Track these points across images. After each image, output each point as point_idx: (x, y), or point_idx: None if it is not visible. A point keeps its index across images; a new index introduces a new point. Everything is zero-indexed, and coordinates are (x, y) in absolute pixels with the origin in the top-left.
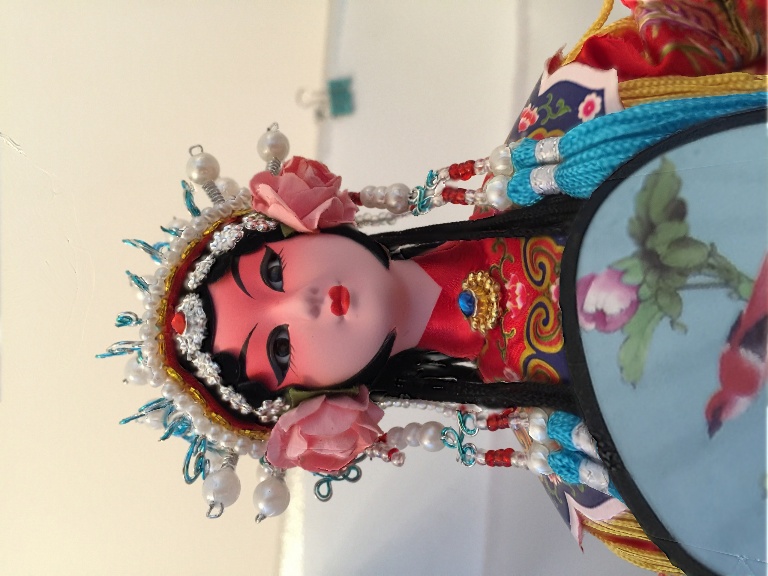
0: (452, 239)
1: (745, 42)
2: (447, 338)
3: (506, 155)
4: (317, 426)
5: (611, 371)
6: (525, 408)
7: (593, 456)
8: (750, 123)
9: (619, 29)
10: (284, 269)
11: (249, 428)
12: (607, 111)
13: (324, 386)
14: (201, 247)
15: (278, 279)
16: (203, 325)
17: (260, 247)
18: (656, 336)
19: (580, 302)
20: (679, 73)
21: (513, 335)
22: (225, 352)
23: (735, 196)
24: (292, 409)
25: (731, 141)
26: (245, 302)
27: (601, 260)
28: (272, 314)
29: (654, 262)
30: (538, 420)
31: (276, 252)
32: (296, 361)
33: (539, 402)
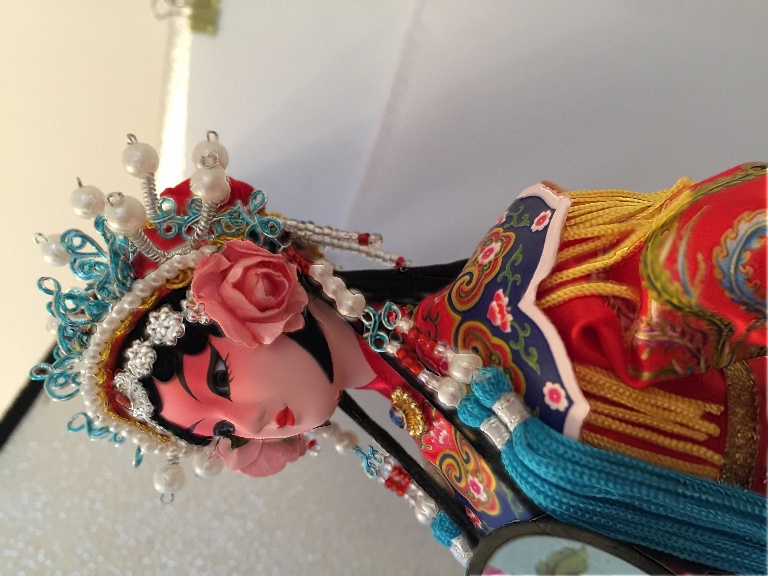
0: None
1: (719, 361)
2: None
3: (467, 367)
4: (255, 468)
5: None
6: None
7: None
8: (652, 575)
9: (621, 298)
10: (231, 382)
11: None
12: (567, 421)
13: None
14: (135, 320)
15: (224, 381)
16: (150, 411)
17: (204, 348)
18: None
19: None
20: (646, 386)
21: (429, 449)
22: (172, 426)
23: None
24: None
25: (633, 575)
26: (192, 404)
27: (509, 567)
28: None
29: None
30: (431, 504)
31: (222, 356)
32: (239, 435)
33: (435, 500)
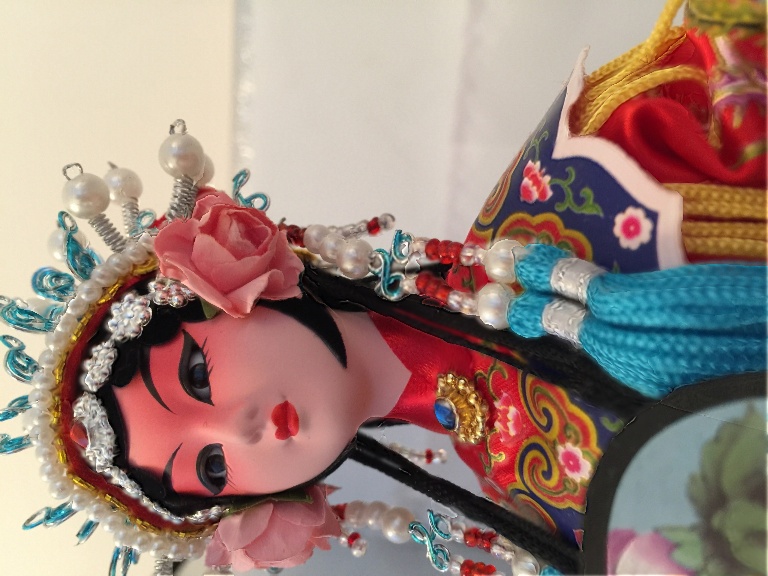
0: (427, 332)
1: None
2: (415, 412)
3: (506, 255)
4: (265, 548)
5: None
6: None
7: None
8: None
9: (679, 81)
10: (210, 374)
11: (183, 529)
12: (660, 249)
13: (271, 493)
14: (96, 321)
15: (204, 381)
16: (111, 442)
17: (176, 335)
18: None
19: (612, 562)
20: (762, 182)
21: (501, 460)
22: (144, 471)
23: None
24: (234, 516)
25: None
26: (163, 418)
27: (646, 517)
28: (200, 434)
29: (722, 550)
30: (527, 564)
31: (198, 343)
32: (235, 480)
33: (530, 549)
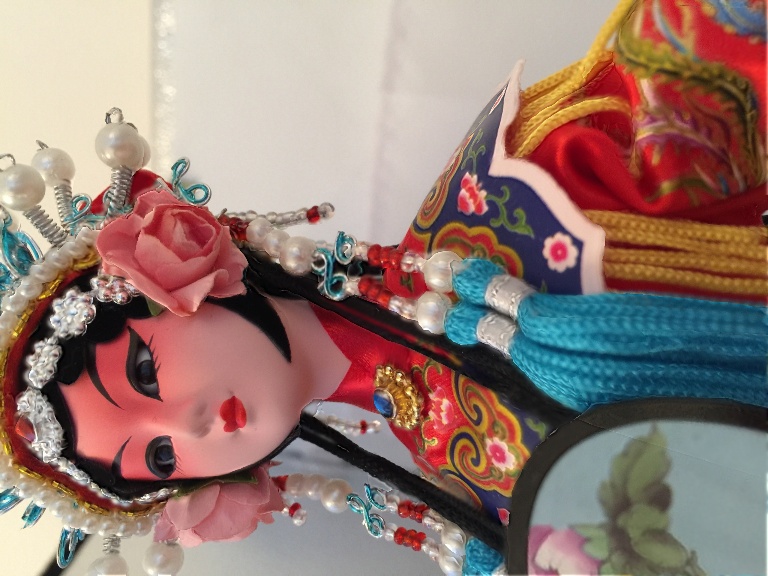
0: (368, 329)
1: (756, 168)
2: (353, 394)
3: (444, 267)
4: (213, 527)
5: None
6: None
7: None
8: None
9: (606, 112)
10: (158, 371)
11: (131, 509)
12: (583, 275)
13: (217, 476)
14: (37, 317)
15: (151, 377)
16: (59, 437)
17: (121, 332)
18: None
19: (532, 551)
20: (674, 214)
21: (434, 444)
22: (93, 462)
23: (731, 510)
24: (181, 496)
25: (741, 443)
26: (112, 413)
27: (562, 515)
28: (149, 428)
29: (624, 544)
30: (455, 535)
31: (144, 340)
32: (183, 467)
33: (458, 522)
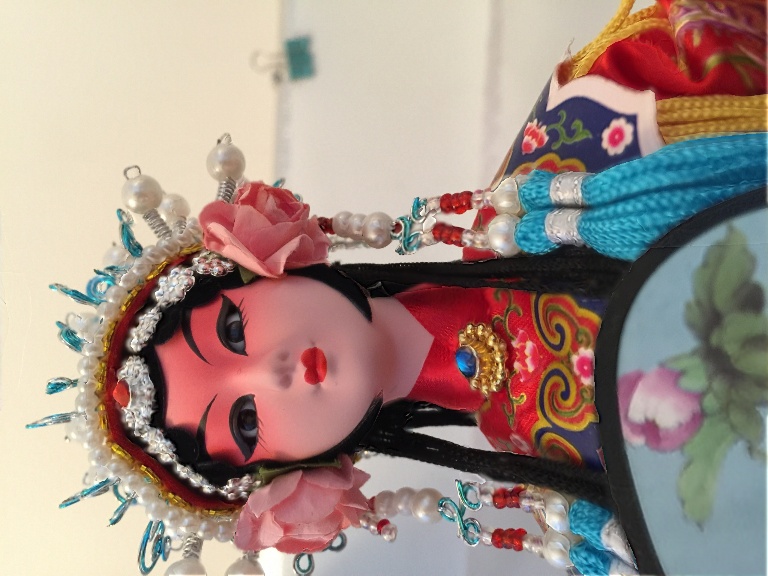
0: (446, 284)
1: None
2: (440, 389)
3: (511, 189)
4: (294, 511)
5: (669, 504)
6: (539, 488)
7: (627, 561)
8: None
9: (646, 29)
10: (246, 327)
11: (214, 507)
12: (642, 144)
13: (300, 459)
14: (145, 295)
15: (239, 337)
16: (151, 397)
17: (215, 297)
18: (730, 465)
19: (623, 407)
20: (727, 91)
21: (523, 402)
22: (179, 428)
23: None
24: (263, 486)
25: None
26: (200, 369)
27: (650, 354)
28: (234, 383)
29: (723, 365)
30: (556, 506)
31: (235, 303)
32: (265, 436)
33: (557, 486)
